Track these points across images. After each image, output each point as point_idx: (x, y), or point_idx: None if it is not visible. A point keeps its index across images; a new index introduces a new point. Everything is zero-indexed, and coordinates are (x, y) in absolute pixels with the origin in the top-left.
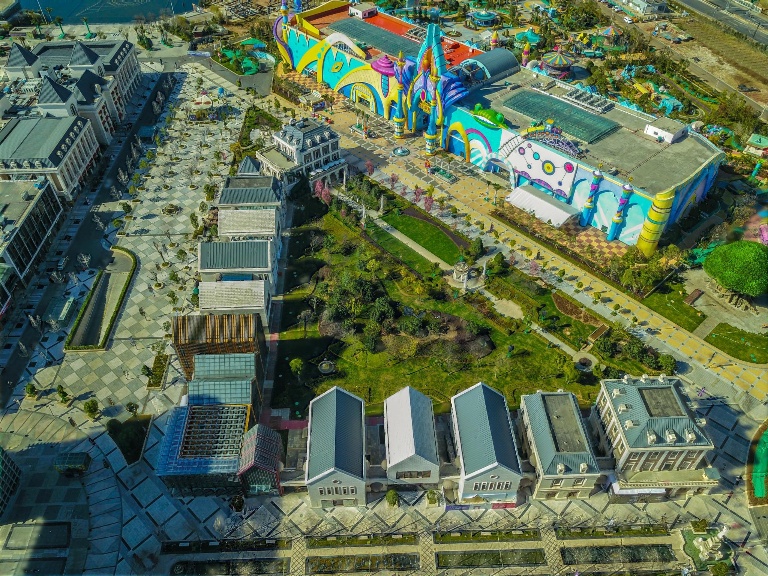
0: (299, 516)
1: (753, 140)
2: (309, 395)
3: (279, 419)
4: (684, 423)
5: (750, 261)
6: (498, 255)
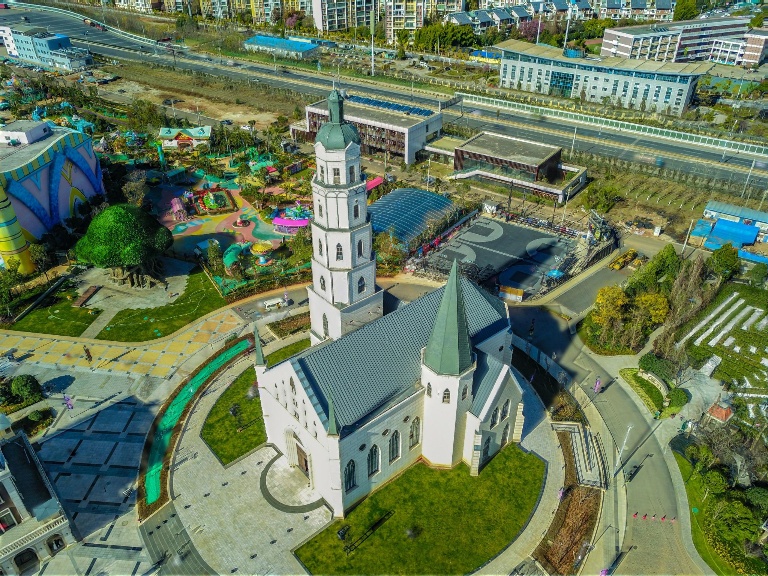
0: None
1: (163, 133)
2: None
3: None
4: None
5: (111, 225)
6: None
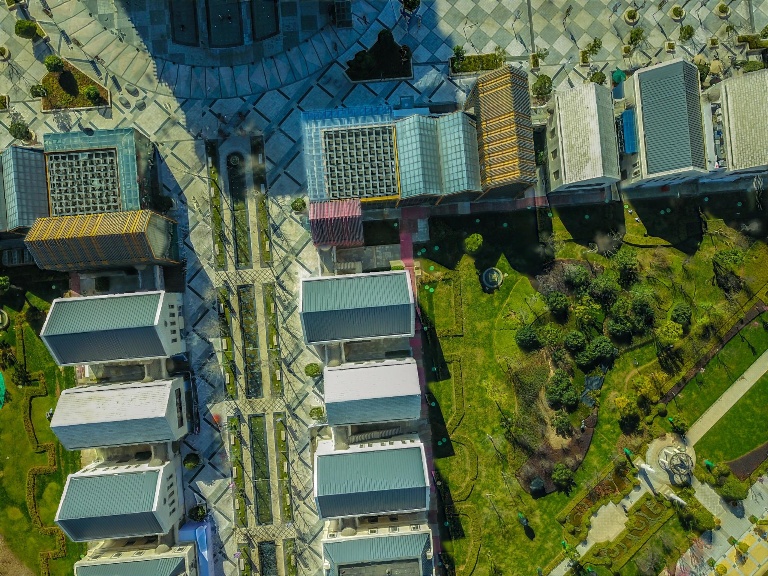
0: (296, 271)
1: None
2: (449, 261)
3: (414, 230)
4: None
5: None
6: (709, 522)
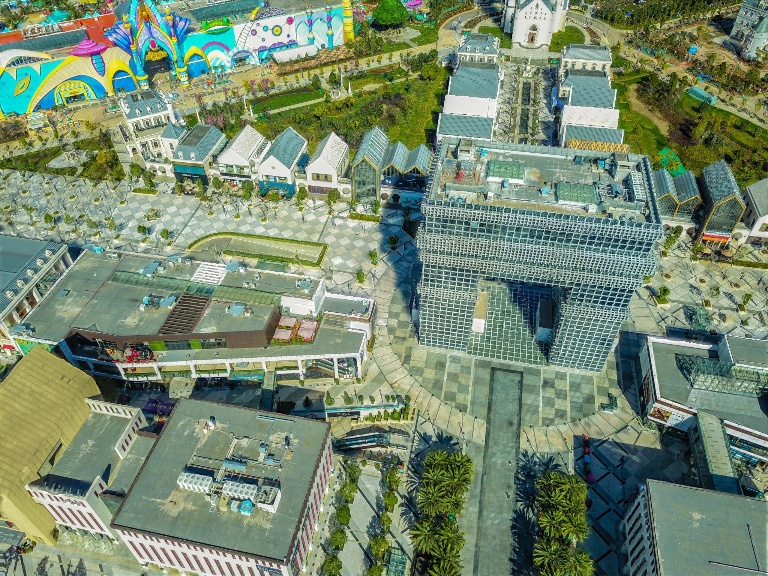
0: None
1: None
2: None
3: None
4: (491, 37)
5: (397, 4)
6: (333, 74)
